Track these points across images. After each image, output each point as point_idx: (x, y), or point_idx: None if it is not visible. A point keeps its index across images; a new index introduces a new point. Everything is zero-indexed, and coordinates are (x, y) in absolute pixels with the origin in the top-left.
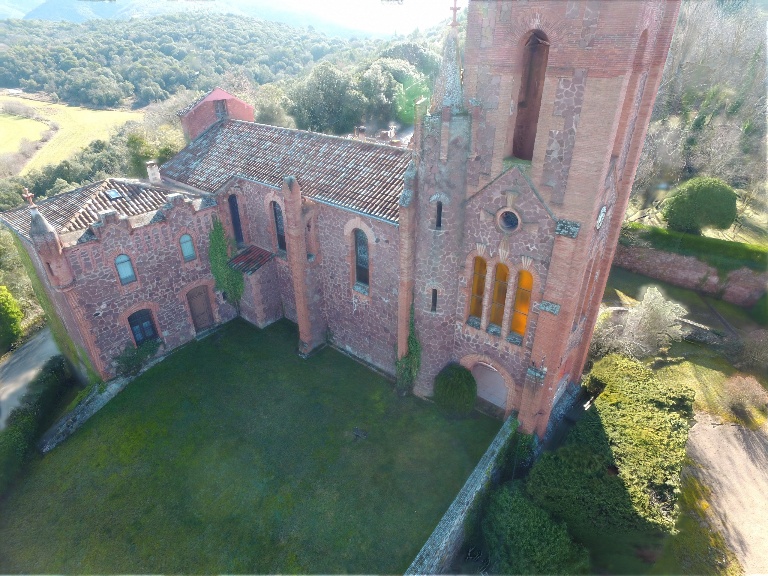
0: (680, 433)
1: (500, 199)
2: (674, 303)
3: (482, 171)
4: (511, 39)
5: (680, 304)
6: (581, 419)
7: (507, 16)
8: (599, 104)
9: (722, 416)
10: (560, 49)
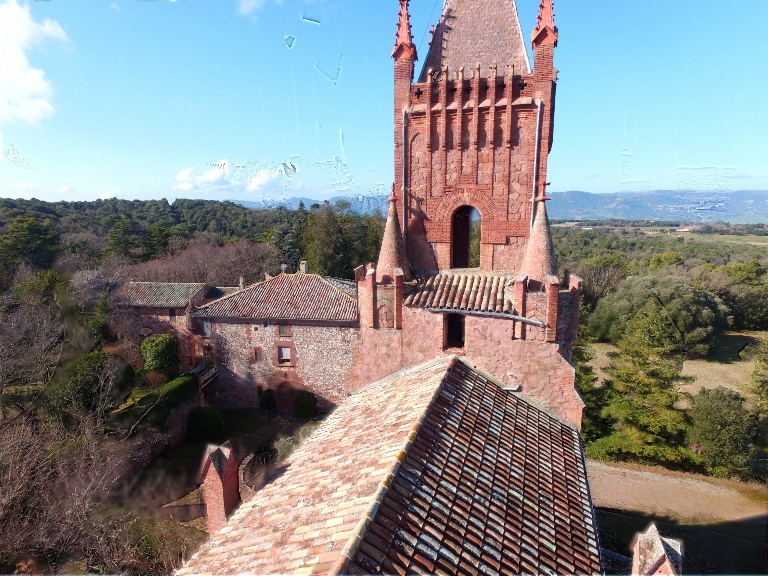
0: None
1: None
2: (186, 474)
3: None
4: None
5: (187, 471)
6: None
7: None
8: None
9: None
10: None
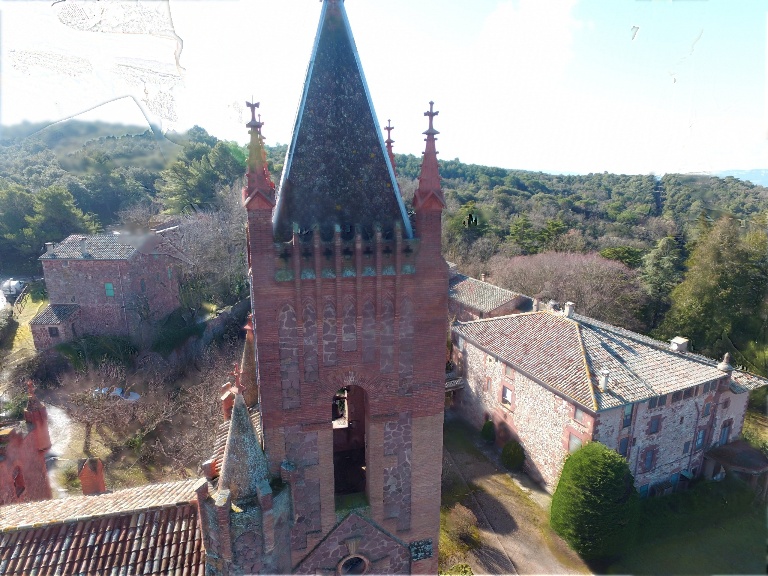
0: None
1: (339, 550)
2: None
3: (309, 530)
4: (323, 397)
5: None
6: None
7: (314, 376)
8: (428, 437)
9: (460, 551)
10: (381, 399)
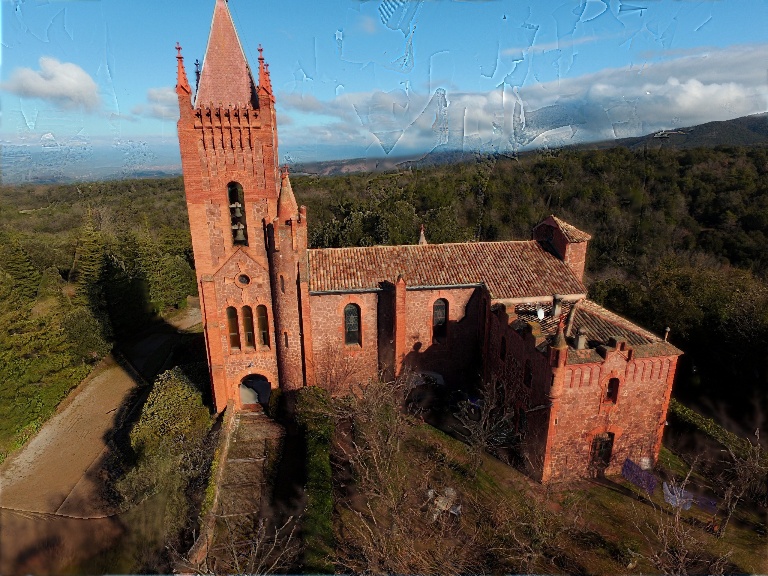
0: (148, 405)
1: None
2: None
3: None
4: None
5: None
6: (207, 383)
7: None
8: None
9: None
10: None
